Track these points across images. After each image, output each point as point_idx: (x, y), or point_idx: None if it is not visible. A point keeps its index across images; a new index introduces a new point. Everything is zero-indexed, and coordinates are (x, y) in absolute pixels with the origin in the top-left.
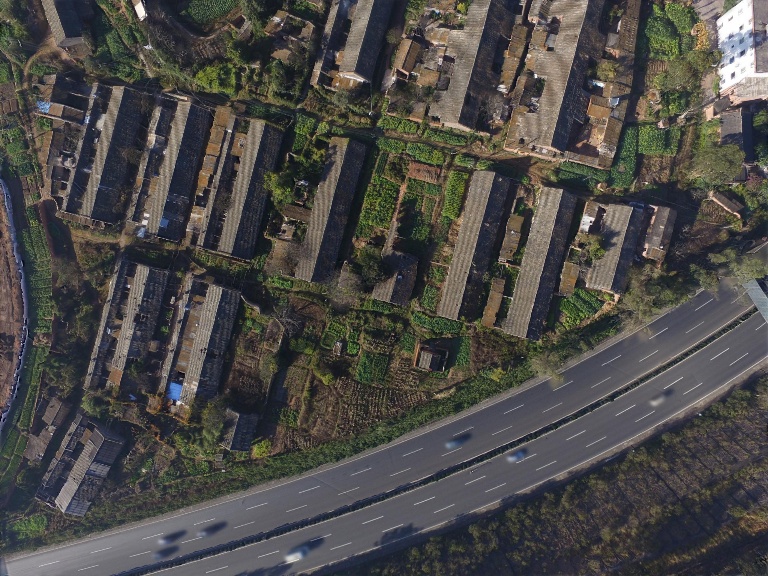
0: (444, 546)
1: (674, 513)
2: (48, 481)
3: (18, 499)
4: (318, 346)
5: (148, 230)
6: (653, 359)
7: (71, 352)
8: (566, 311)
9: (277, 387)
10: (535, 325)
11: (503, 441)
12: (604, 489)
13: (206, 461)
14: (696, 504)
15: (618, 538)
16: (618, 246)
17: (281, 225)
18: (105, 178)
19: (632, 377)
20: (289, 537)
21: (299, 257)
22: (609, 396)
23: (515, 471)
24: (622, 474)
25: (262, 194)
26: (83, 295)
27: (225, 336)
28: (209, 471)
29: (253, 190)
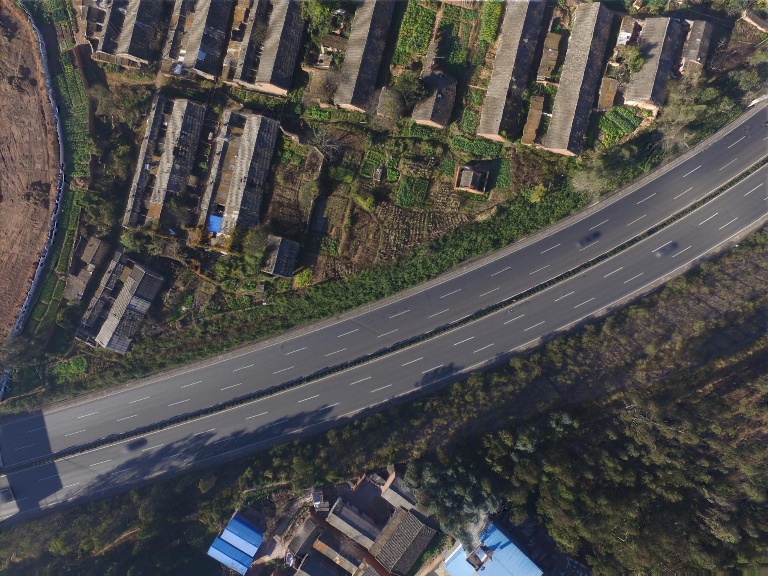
0: (486, 379)
1: (718, 326)
2: (88, 319)
3: (57, 342)
4: (357, 175)
5: (185, 65)
6: (688, 196)
7: (109, 190)
8: (605, 129)
9: (317, 217)
10: (575, 138)
11: (541, 280)
12: (645, 315)
13: (247, 295)
14: (739, 317)
15: (662, 353)
16: (656, 57)
17: (318, 57)
18: (141, 14)
19: (667, 214)
20: (329, 381)
21: (338, 81)
22: (645, 232)
23: (553, 309)
24: (662, 301)
25: (299, 24)
26: (120, 137)
27: (264, 166)
28: (250, 305)
29: (290, 19)
